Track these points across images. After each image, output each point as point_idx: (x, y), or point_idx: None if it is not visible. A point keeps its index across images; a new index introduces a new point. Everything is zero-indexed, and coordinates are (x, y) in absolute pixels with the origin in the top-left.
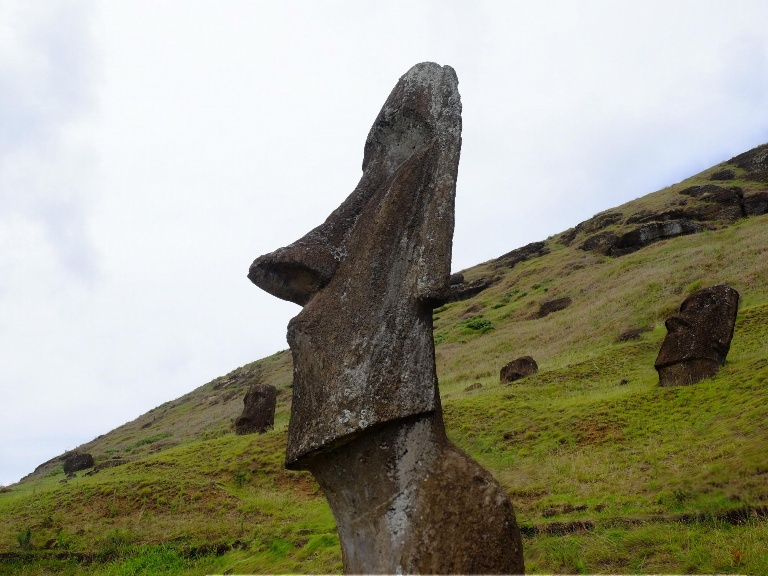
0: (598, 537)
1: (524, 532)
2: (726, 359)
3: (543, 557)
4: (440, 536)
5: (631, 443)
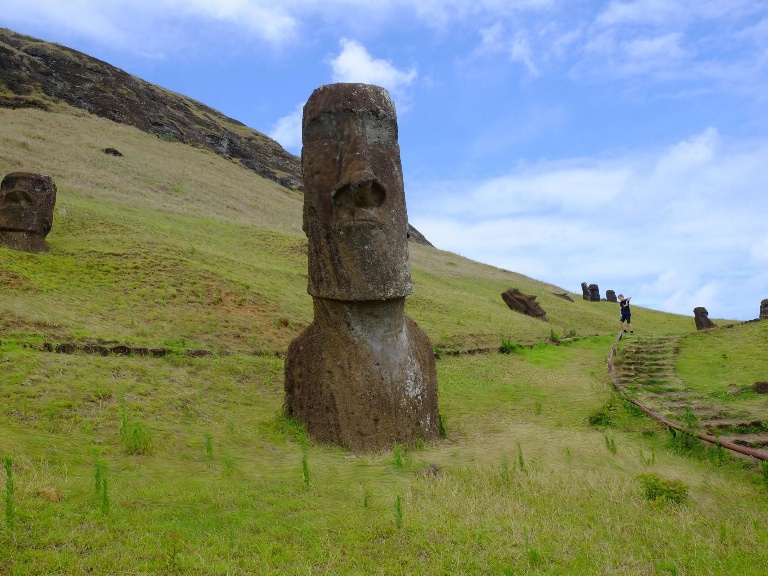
0: (225, 360)
1: (174, 353)
2: (45, 239)
3: (213, 369)
4: (417, 345)
5: (53, 295)
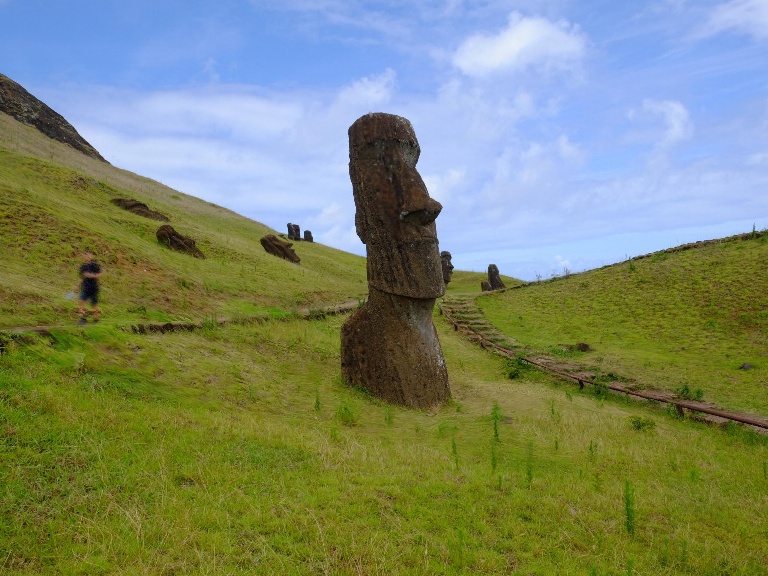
0: (227, 331)
1: (198, 328)
2: None
3: None
4: None
5: None
